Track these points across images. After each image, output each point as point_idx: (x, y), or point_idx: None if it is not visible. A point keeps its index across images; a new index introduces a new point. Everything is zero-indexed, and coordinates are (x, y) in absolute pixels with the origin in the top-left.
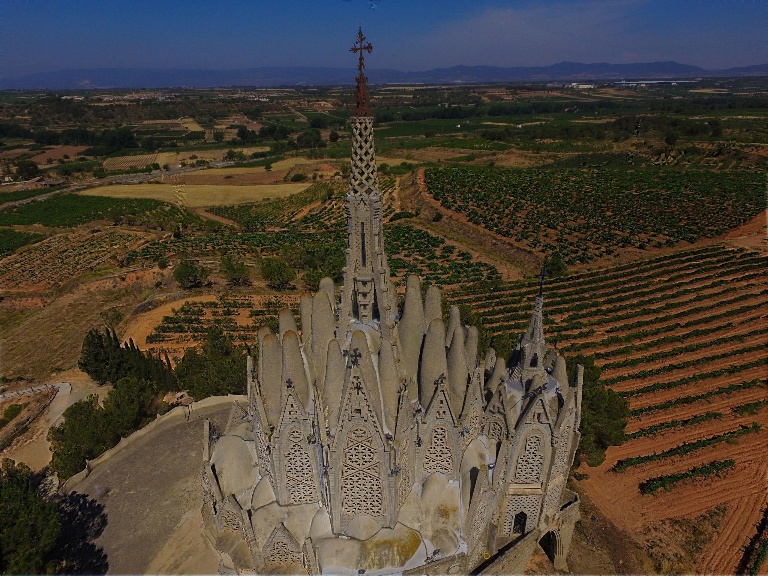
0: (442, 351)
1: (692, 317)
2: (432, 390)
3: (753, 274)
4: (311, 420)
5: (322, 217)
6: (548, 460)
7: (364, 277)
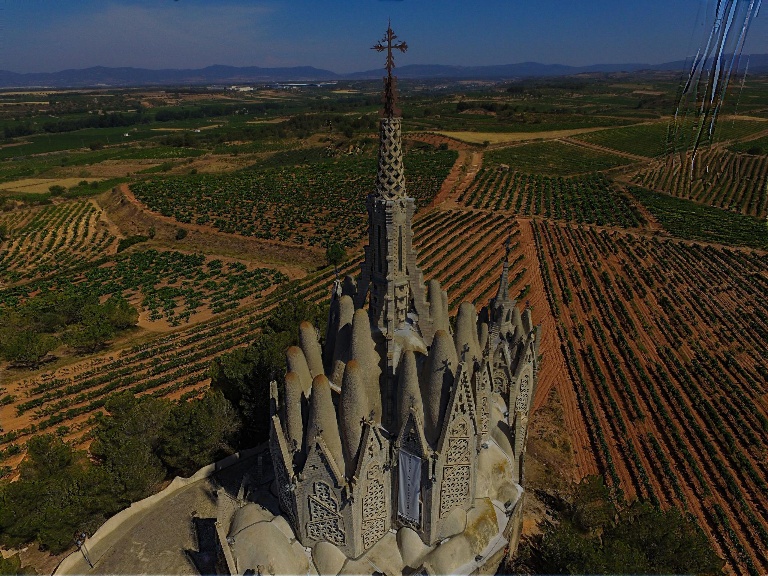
0: (471, 329)
1: (453, 268)
2: (472, 367)
3: (469, 227)
4: (388, 446)
5: (8, 265)
6: (531, 391)
7: (401, 281)
